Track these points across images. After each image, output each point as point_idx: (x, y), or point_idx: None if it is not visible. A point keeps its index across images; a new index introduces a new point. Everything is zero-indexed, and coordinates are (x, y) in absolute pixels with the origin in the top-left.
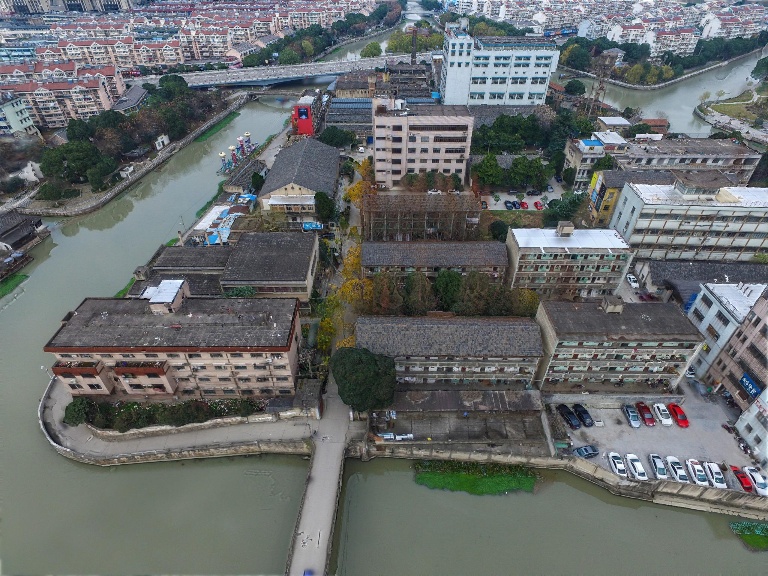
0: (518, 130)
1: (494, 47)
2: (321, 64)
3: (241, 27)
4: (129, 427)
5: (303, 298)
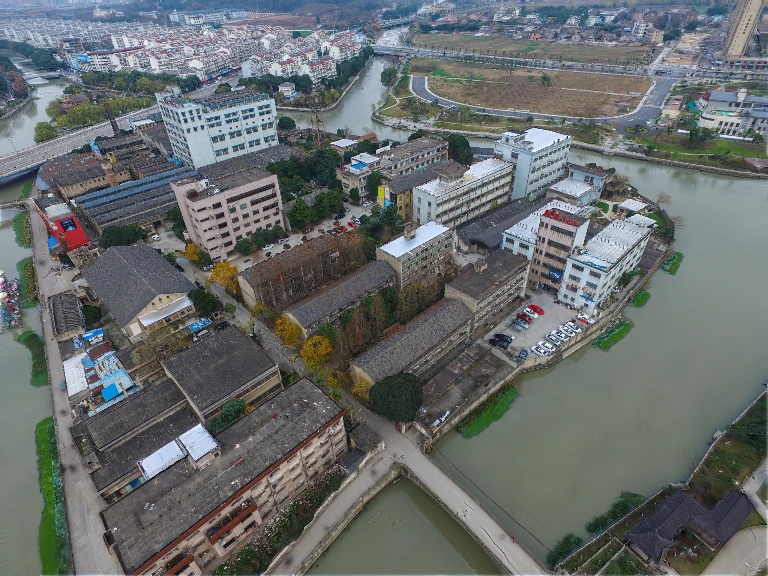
0: (288, 172)
1: (219, 107)
2: None
3: None
4: (259, 575)
5: (274, 382)
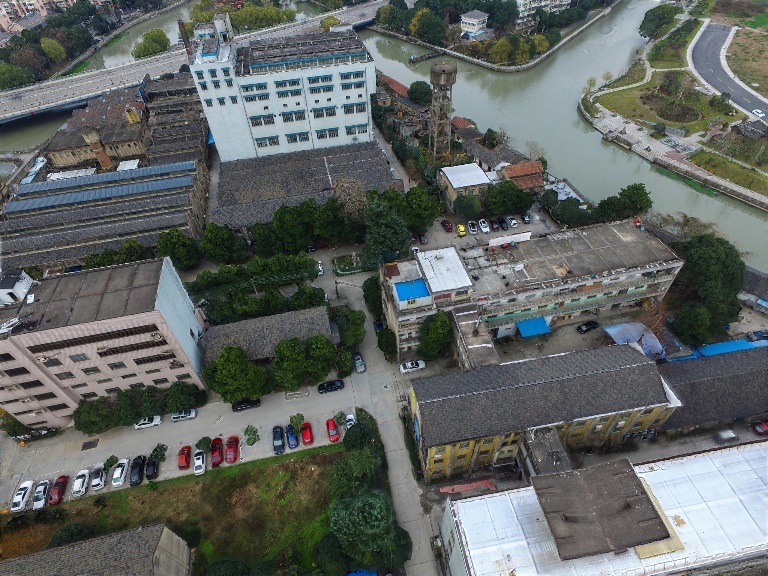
0: (313, 228)
1: (269, 67)
2: (66, 80)
3: None
4: None
5: None
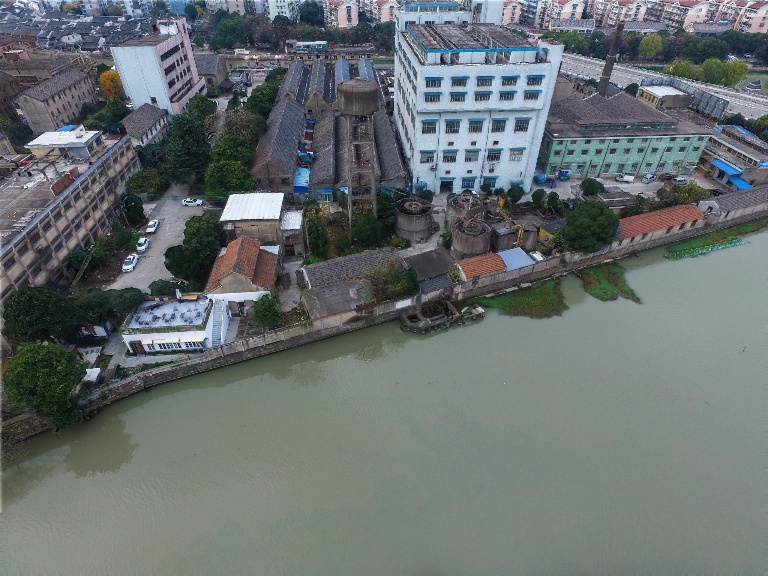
0: None
1: None
2: (587, 60)
3: (620, 4)
4: None
5: None
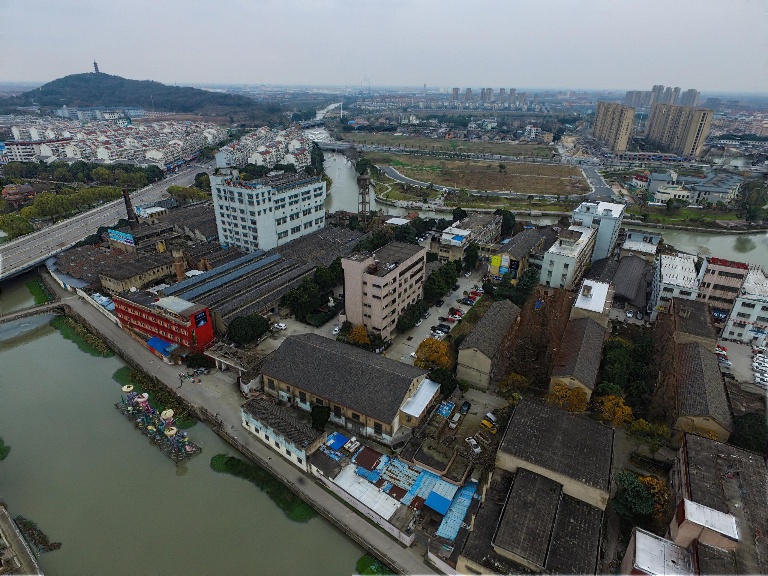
0: None
1: (284, 189)
2: None
3: None
4: None
5: None
